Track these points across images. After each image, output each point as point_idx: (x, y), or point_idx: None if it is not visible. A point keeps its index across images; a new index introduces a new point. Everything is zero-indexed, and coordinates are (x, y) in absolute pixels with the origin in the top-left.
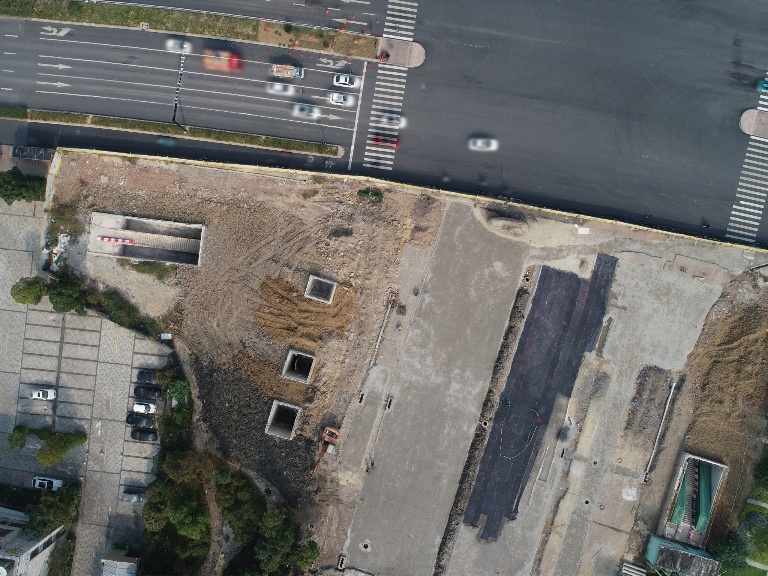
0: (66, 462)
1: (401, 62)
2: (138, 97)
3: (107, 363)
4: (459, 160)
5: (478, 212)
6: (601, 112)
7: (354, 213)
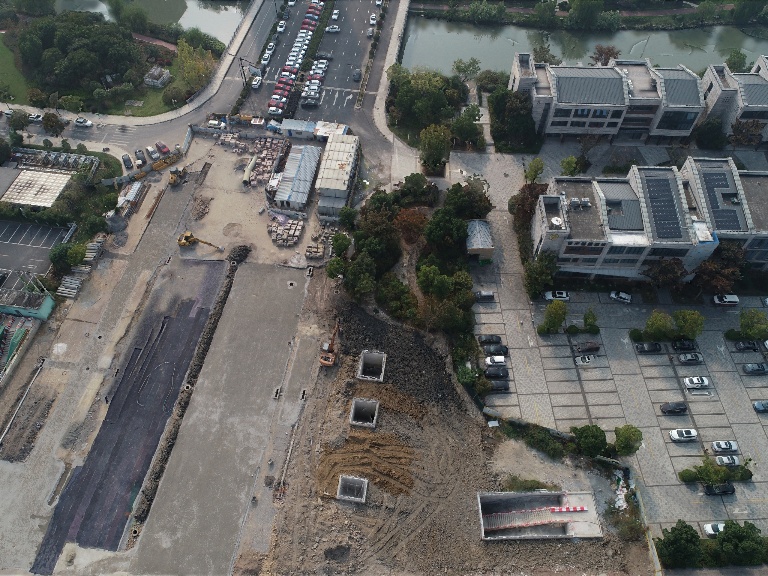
0: None
1: None
2: None
3: (540, 394)
4: None
5: None
6: None
7: None
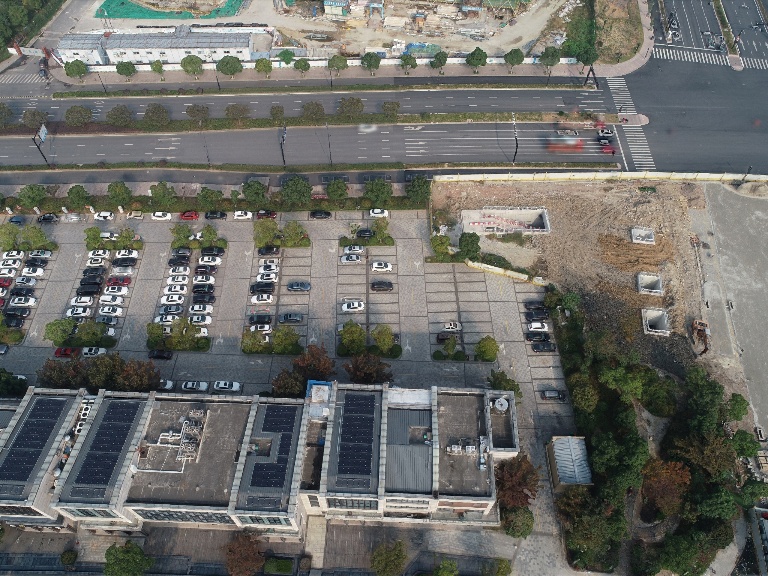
0: (482, 378)
1: (635, 123)
2: (475, 152)
3: (496, 302)
4: (698, 163)
5: (727, 187)
6: None
7: (644, 195)
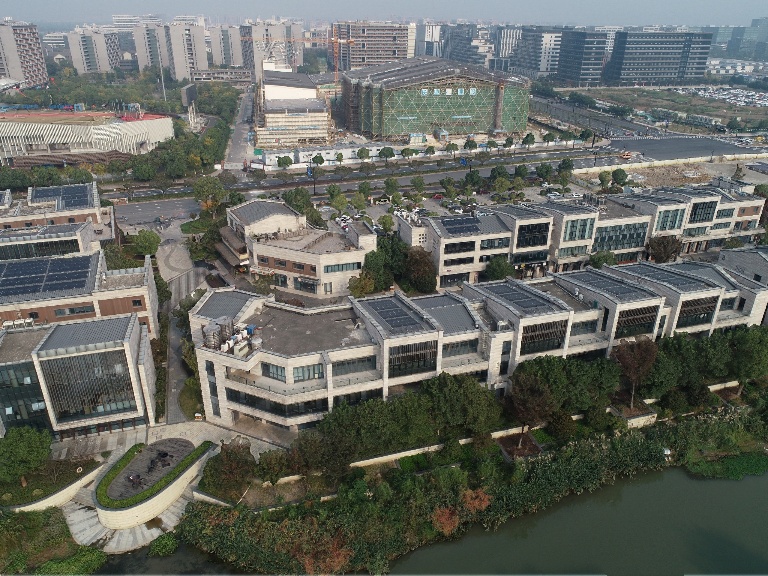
0: None
1: None
2: None
3: None
4: None
5: None
6: (703, 150)
7: None
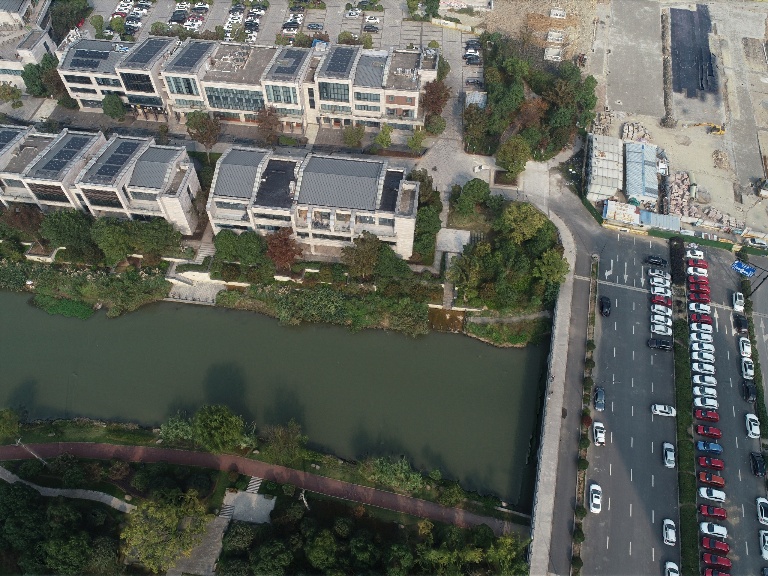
0: None
1: None
2: None
3: (448, 41)
4: None
5: None
6: None
7: None
